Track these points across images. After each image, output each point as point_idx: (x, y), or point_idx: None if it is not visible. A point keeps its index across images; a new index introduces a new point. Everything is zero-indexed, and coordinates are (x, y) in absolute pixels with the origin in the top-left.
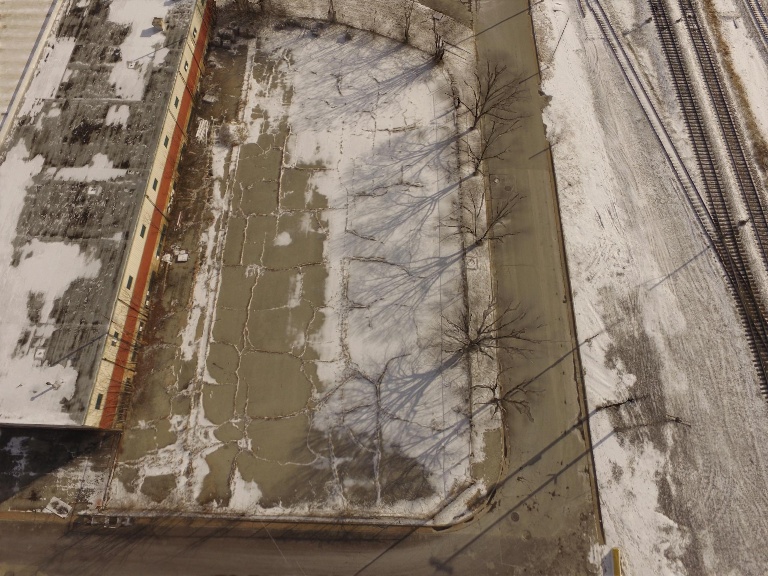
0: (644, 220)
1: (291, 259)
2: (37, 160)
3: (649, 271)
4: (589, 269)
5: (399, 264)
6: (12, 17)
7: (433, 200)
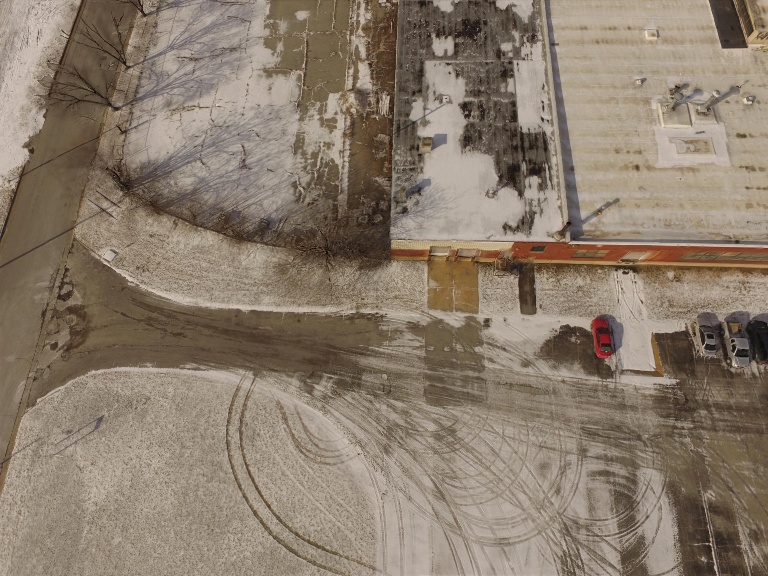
0: (2, 35)
1: (296, 2)
2: (503, 5)
3: (21, 1)
4: (66, 2)
5: (211, 1)
6: (616, 166)
7: (172, 47)
